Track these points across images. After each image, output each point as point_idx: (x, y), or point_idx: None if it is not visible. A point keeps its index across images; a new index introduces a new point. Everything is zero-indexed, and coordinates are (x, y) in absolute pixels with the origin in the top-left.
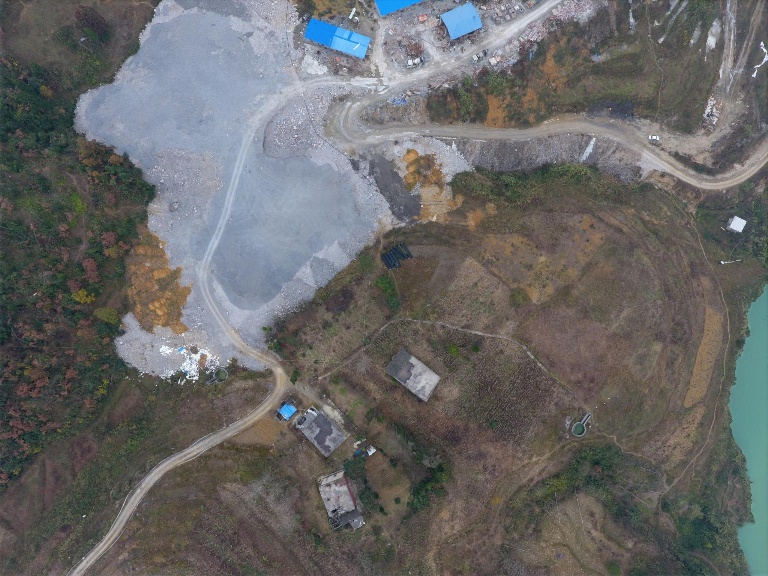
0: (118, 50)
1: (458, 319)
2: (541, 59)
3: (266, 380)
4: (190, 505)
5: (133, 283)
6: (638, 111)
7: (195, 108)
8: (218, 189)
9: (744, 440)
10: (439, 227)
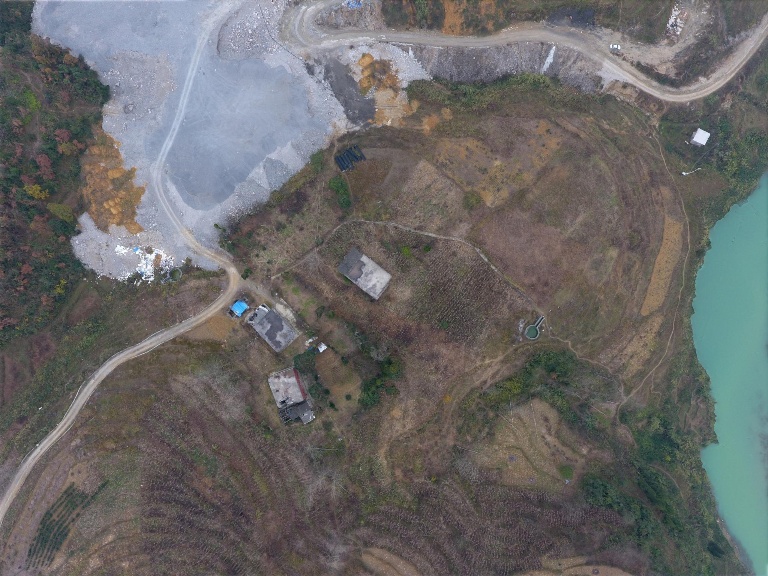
0: None
1: (411, 220)
2: None
3: (219, 279)
4: (141, 395)
5: (88, 182)
6: (599, 19)
7: (150, 11)
8: (172, 91)
9: (710, 362)
10: (393, 131)
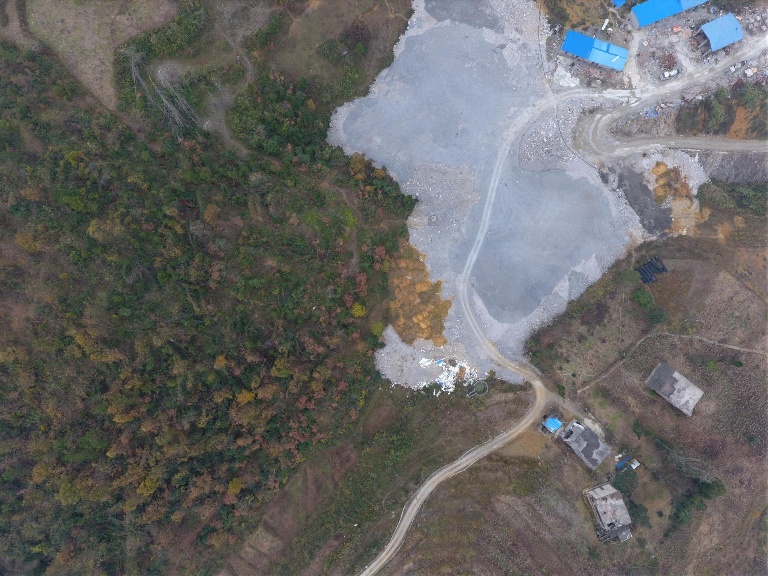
0: (373, 63)
1: (715, 333)
2: None
3: (526, 393)
4: (469, 517)
5: (397, 296)
6: None
7: (450, 121)
8: (476, 203)
9: None
10: (691, 241)
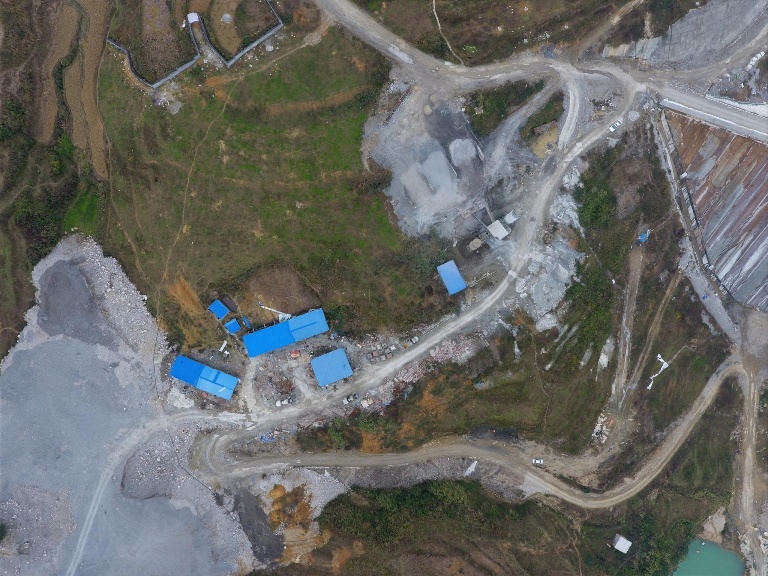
0: None
1: None
2: (417, 397)
3: None
4: None
5: None
6: (522, 435)
7: (53, 442)
8: (71, 531)
9: None
10: (301, 571)
